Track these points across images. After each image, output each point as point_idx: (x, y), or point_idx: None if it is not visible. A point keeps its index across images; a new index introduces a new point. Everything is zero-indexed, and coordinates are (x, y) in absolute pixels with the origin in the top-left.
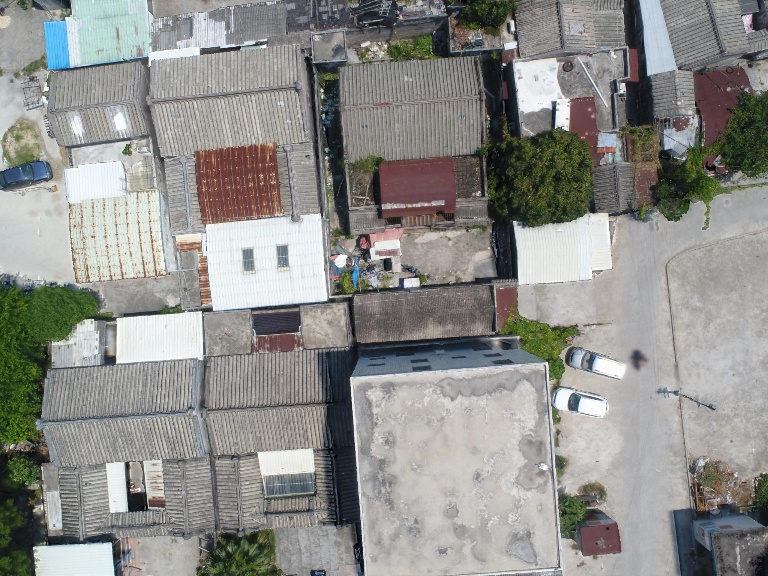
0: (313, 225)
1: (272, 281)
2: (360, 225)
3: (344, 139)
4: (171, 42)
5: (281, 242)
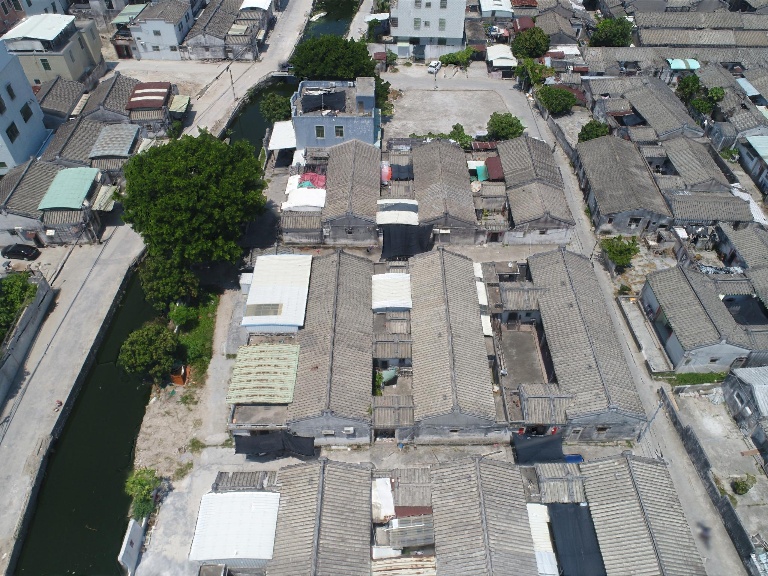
0: (510, 10)
1: (490, 3)
2: (510, 24)
3: (542, 14)
4: (573, 1)
5: (503, 5)
